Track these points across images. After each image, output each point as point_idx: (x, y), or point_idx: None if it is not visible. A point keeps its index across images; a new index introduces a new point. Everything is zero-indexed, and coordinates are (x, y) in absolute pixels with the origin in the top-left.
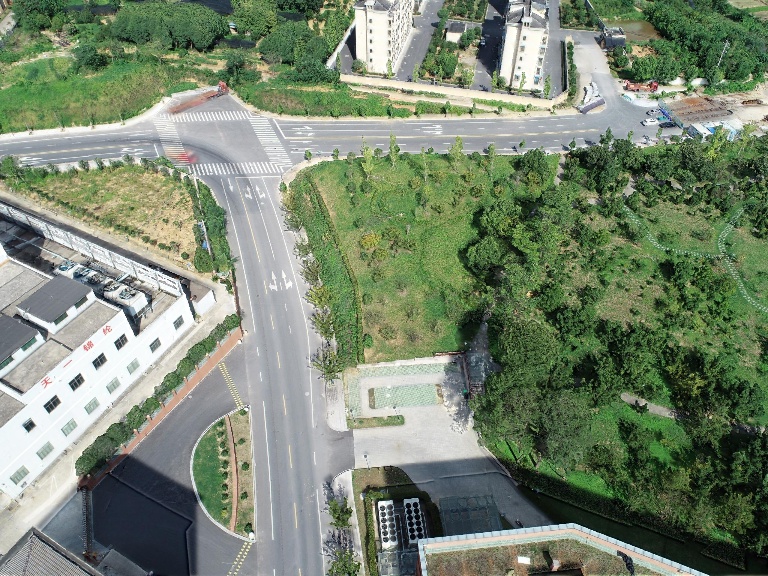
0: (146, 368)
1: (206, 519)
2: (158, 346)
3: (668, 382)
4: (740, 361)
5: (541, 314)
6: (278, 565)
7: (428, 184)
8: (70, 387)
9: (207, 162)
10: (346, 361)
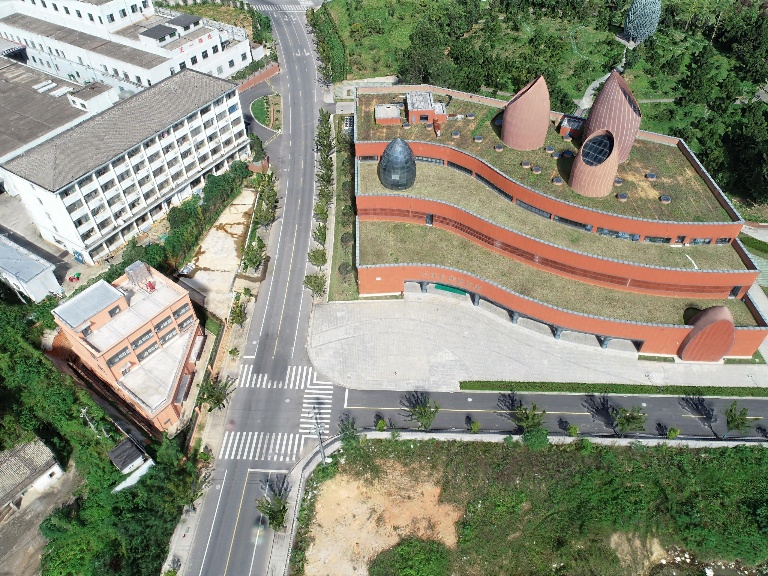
0: (226, 76)
1: (257, 124)
2: (233, 66)
3: (515, 84)
4: (559, 76)
5: (452, 60)
6: (292, 140)
7: (397, 6)
8: (191, 61)
9: (261, 5)
10: (336, 79)
